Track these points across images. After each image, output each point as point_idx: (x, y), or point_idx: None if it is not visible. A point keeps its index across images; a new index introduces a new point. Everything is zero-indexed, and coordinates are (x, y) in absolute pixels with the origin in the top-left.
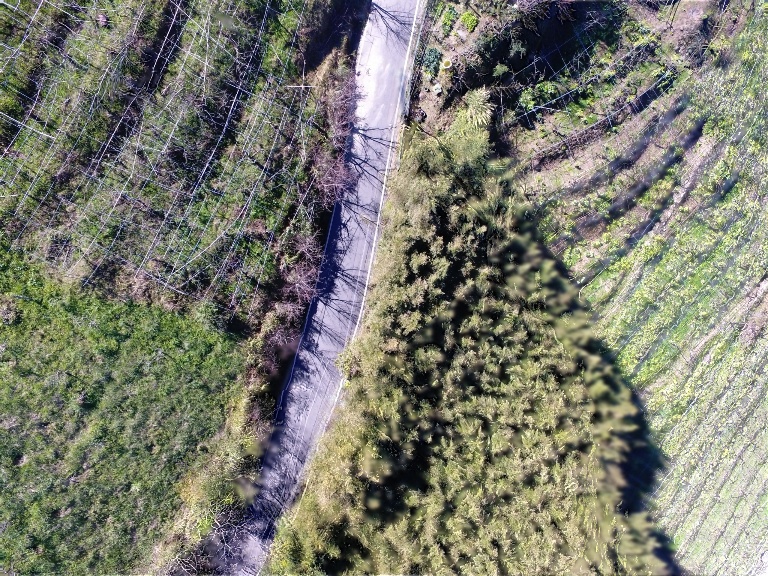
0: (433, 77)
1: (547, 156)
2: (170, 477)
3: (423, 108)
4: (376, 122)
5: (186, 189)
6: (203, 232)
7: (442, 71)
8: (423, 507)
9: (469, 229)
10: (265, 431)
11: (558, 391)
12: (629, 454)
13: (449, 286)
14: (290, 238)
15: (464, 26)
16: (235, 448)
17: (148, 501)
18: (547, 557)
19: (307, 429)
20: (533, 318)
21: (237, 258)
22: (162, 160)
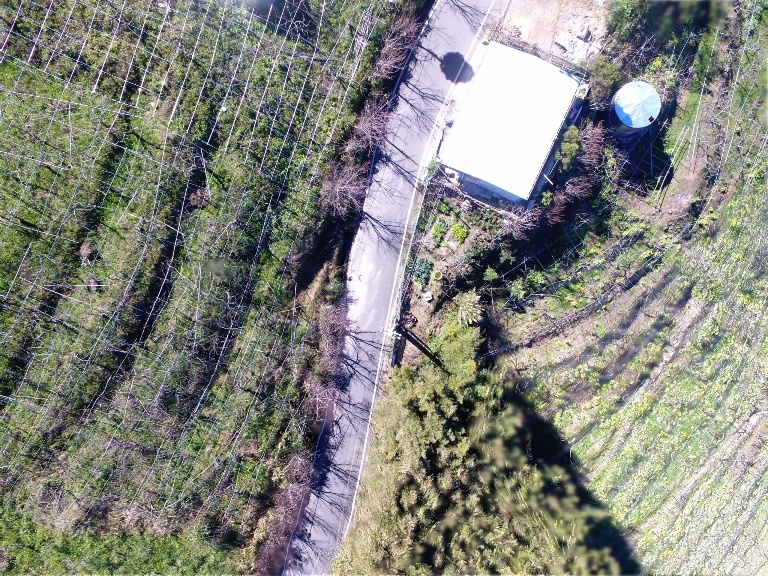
0: (424, 285)
1: (538, 336)
2: None
3: (414, 314)
4: (367, 325)
5: (178, 424)
6: (195, 459)
7: (433, 280)
8: None
9: (459, 465)
10: None
11: None
12: None
13: (439, 513)
14: (282, 454)
15: (454, 238)
16: None
17: None
18: None
19: None
20: (523, 522)
21: (229, 483)
22: (154, 403)
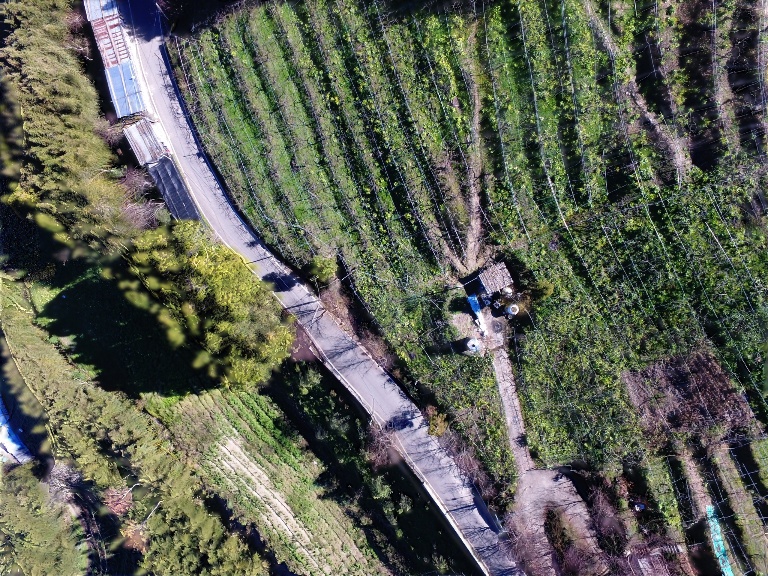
0: None
1: None
2: None
3: None
4: None
5: None
6: None
7: None
8: None
9: None
10: None
11: None
12: None
13: None
14: None
15: None
16: None
17: None
18: None
19: None
20: None
21: None
22: None
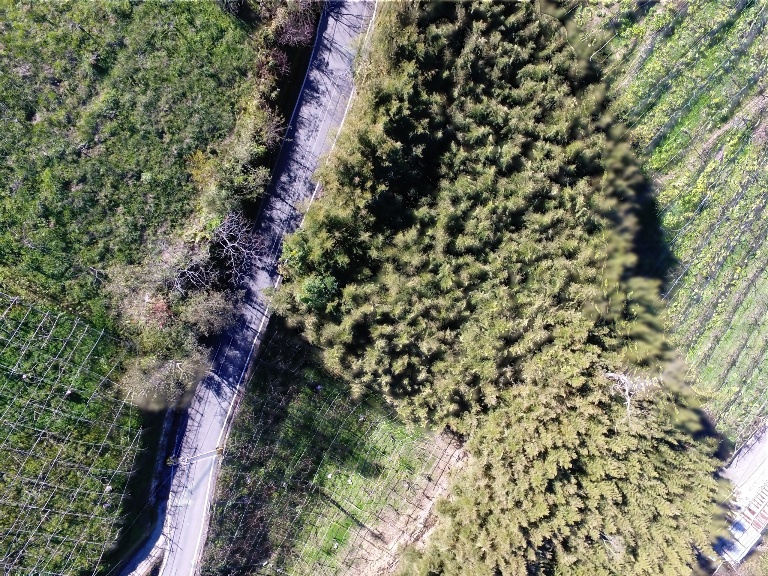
0: None
1: None
2: (180, 176)
3: None
4: None
5: None
6: None
7: None
8: (433, 220)
9: None
10: (275, 145)
11: (570, 96)
12: (640, 246)
13: None
14: None
15: None
16: (245, 156)
17: (158, 201)
18: (558, 282)
19: (317, 147)
20: (545, 14)
21: None
22: None
